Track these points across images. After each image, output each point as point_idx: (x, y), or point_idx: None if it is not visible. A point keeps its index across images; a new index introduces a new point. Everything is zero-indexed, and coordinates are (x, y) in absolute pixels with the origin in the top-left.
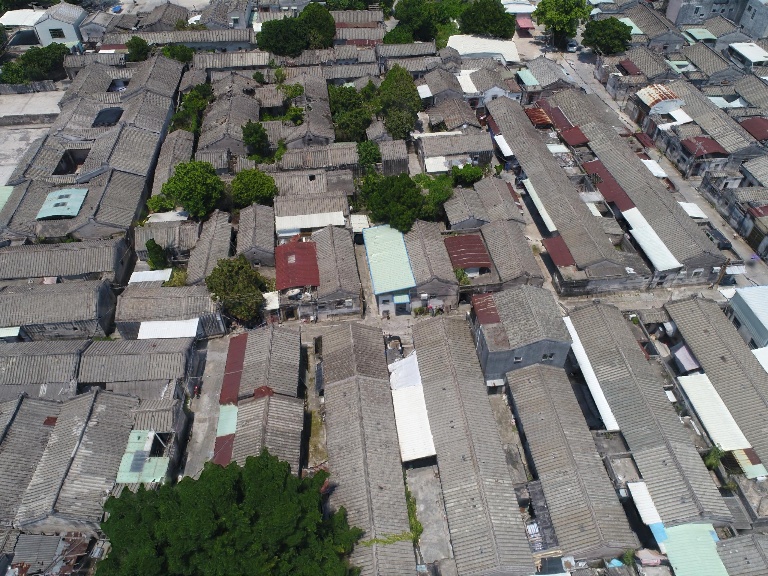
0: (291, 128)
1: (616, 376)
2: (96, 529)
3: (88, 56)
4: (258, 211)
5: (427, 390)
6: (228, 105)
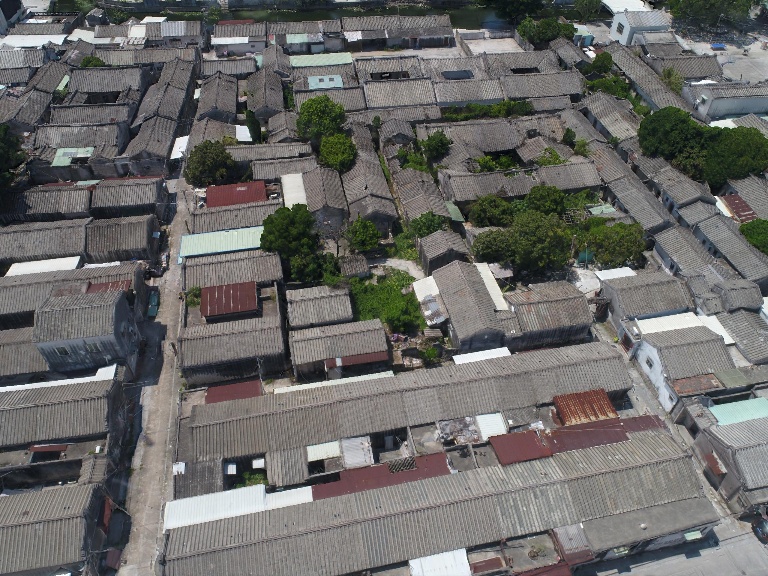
0: (464, 167)
1: (7, 399)
2: None
3: (567, 46)
4: (307, 162)
5: None
6: (489, 122)
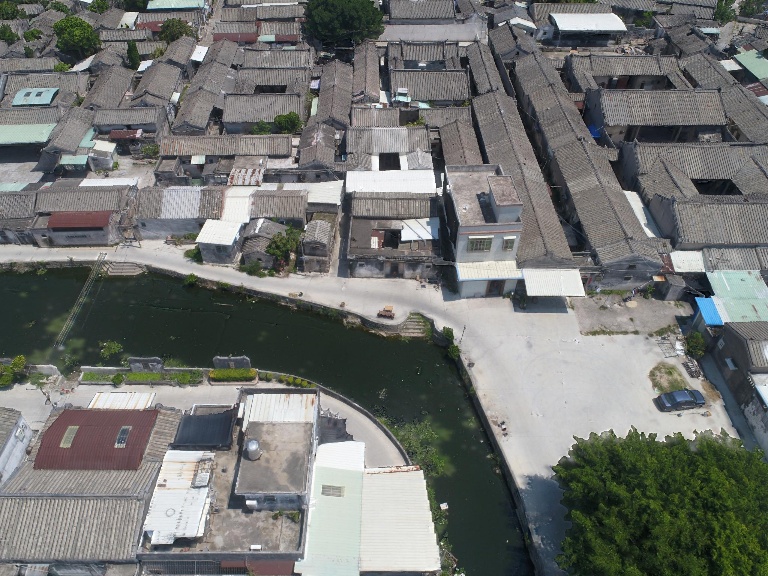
0: None
1: None
2: (313, 59)
3: None
4: None
5: (267, 1)
6: None
